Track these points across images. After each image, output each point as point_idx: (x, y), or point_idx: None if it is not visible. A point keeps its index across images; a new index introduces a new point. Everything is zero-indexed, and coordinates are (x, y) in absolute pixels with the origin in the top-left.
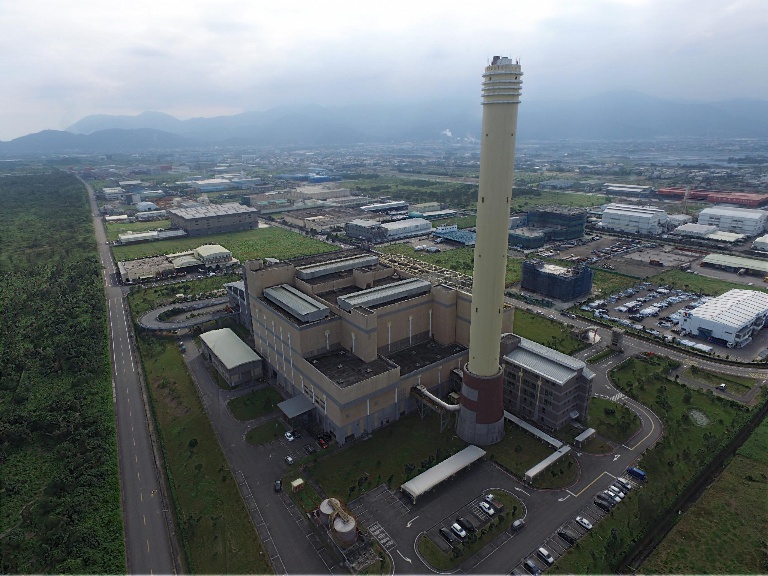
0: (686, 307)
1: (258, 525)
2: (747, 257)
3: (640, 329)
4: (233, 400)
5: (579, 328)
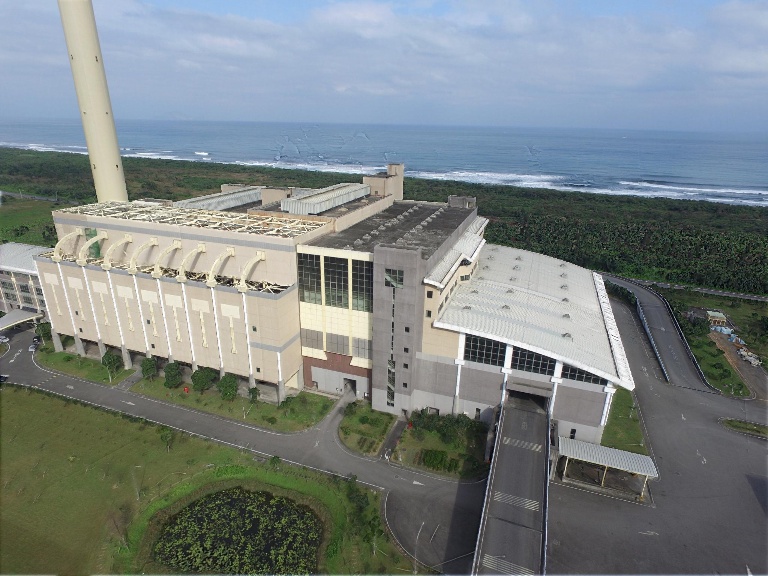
0: None
1: None
2: None
3: None
4: None
5: None
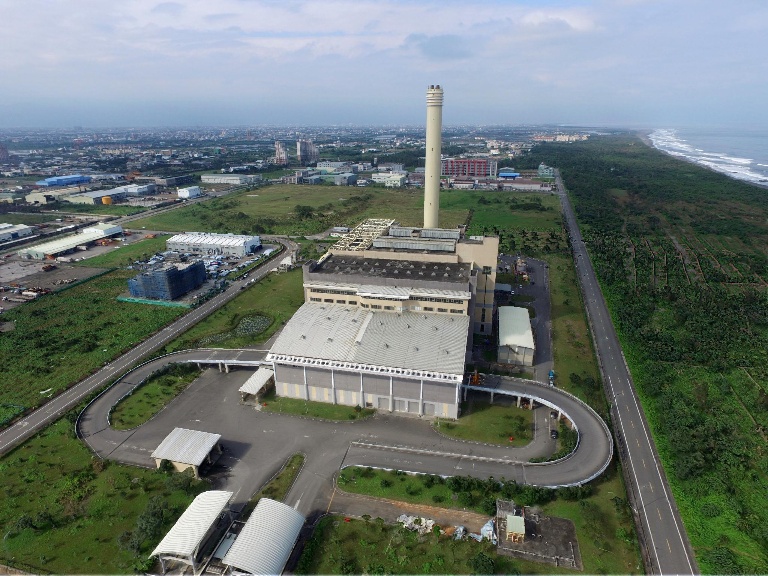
0: (196, 255)
1: (547, 279)
2: (12, 250)
3: (254, 261)
4: (530, 317)
5: (281, 266)
